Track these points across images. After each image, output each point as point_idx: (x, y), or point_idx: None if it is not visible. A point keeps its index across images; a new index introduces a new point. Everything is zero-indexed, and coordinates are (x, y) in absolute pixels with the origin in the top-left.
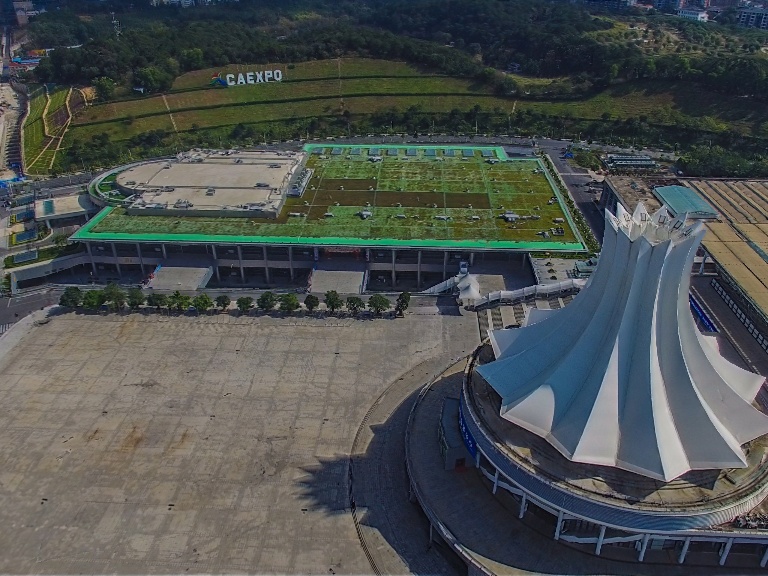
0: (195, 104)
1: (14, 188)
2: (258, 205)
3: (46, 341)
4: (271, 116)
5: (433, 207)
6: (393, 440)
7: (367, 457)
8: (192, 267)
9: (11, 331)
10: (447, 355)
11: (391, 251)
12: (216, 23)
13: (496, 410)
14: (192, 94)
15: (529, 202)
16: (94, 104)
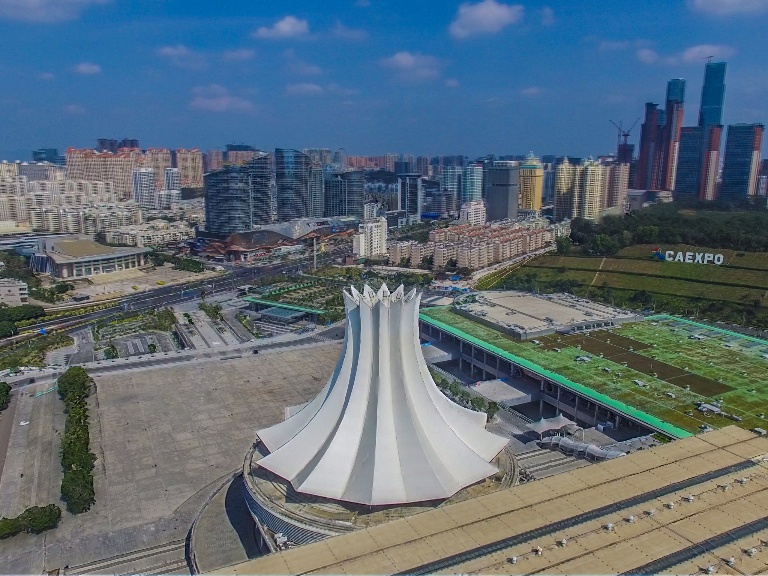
0: (624, 269)
1: (452, 291)
2: (520, 327)
3: (326, 348)
4: (682, 292)
5: (652, 376)
6: None
7: None
8: (443, 350)
9: None
10: None
11: (558, 387)
12: (762, 220)
13: None
14: (629, 261)
15: (767, 409)
16: (550, 255)
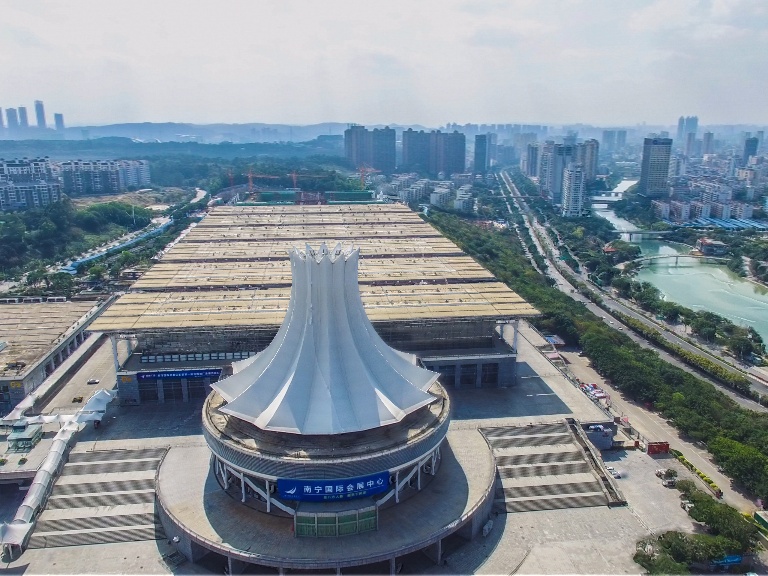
0: None
1: None
2: None
3: None
4: None
5: None
6: None
7: None
8: None
9: None
10: (130, 573)
11: None
12: None
13: (367, 443)
14: None
15: None
16: None
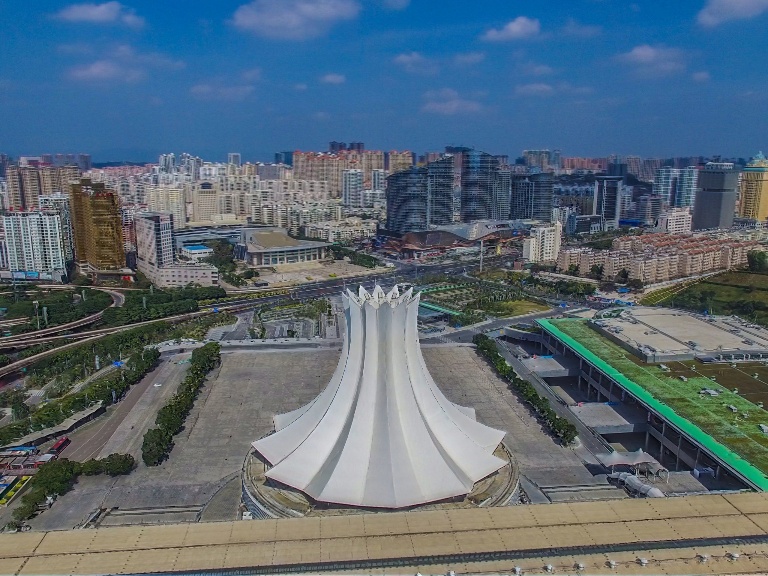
0: None
1: (610, 304)
2: (651, 349)
3: (442, 350)
4: None
5: None
6: None
7: None
8: (562, 365)
9: (450, 344)
10: None
11: None
12: None
13: None
14: None
15: None
16: (738, 271)
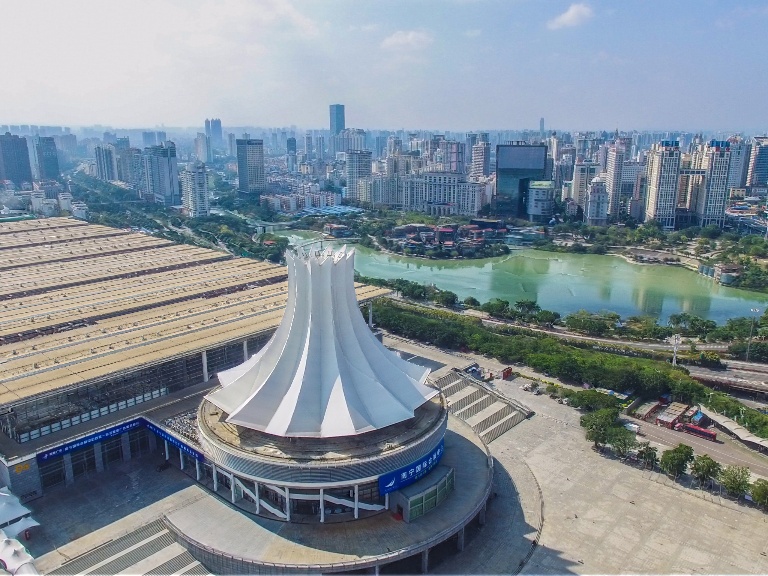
0: None
1: None
2: None
3: None
4: None
5: None
6: (456, 574)
7: (495, 572)
8: None
9: None
10: None
11: None
12: None
13: (421, 419)
14: None
15: None
16: None
